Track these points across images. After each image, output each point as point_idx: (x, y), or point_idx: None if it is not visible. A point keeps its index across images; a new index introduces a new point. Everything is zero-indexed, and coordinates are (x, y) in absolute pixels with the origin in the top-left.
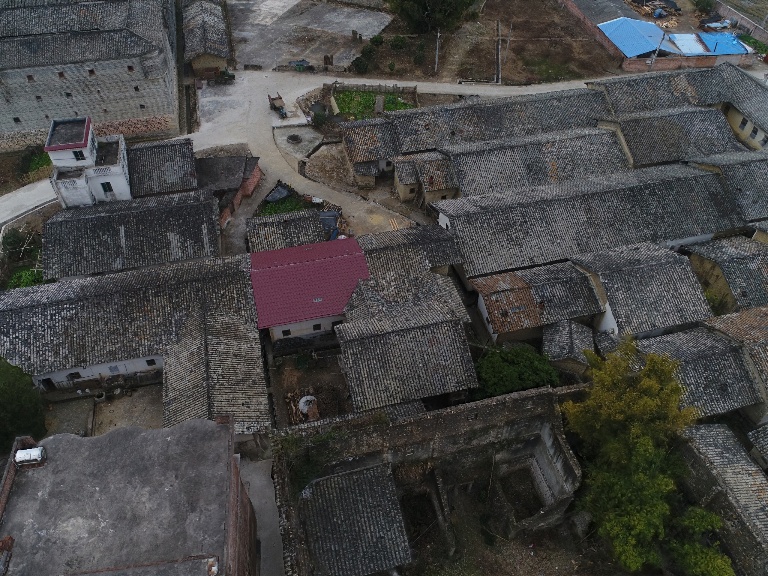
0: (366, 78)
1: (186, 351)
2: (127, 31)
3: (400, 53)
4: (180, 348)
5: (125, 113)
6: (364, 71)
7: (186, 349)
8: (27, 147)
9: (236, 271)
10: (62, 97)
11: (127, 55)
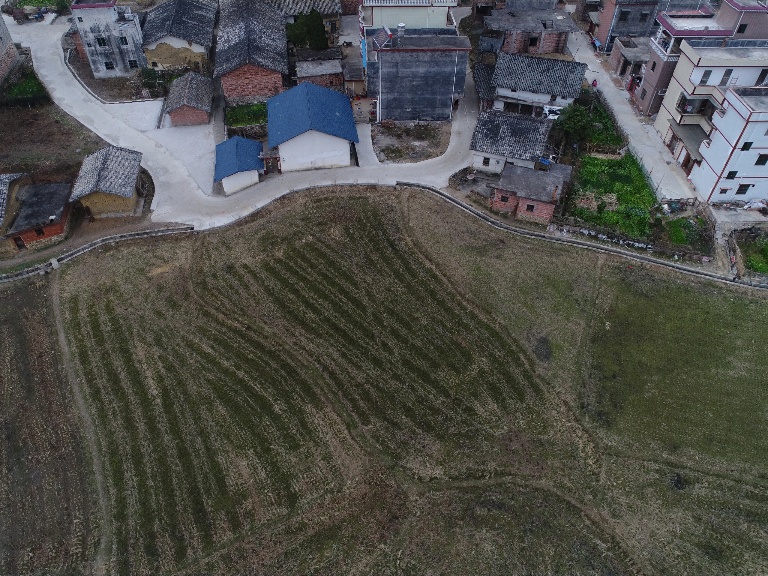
0: None
1: (290, 5)
2: None
3: None
4: (287, 8)
5: None
6: None
7: (289, 5)
8: None
9: None
10: None
11: None
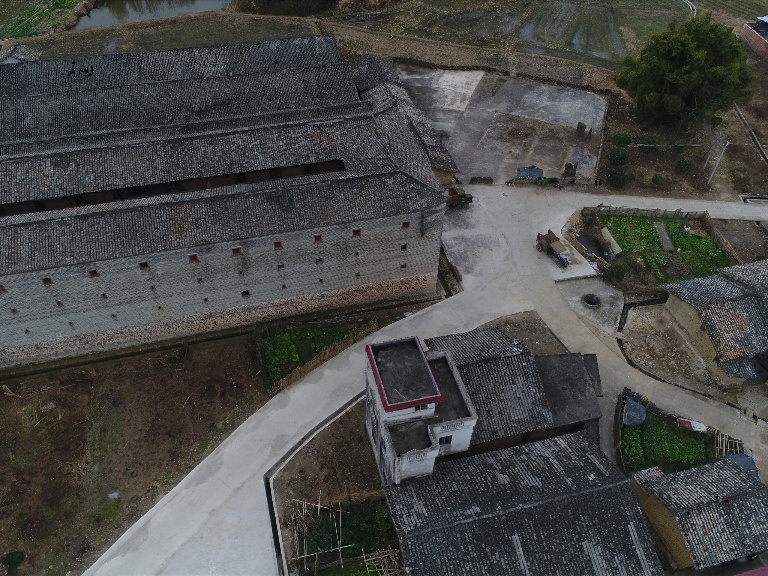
0: (627, 195)
1: None
2: (402, 174)
3: (647, 154)
4: None
5: (380, 275)
6: (623, 185)
7: None
8: (257, 328)
9: None
10: (310, 263)
11: (409, 211)
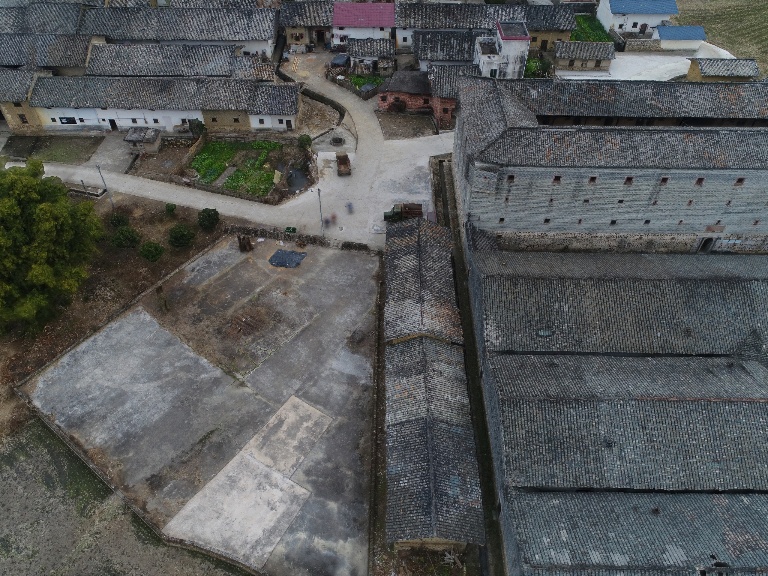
0: None
1: None
2: None
3: (125, 256)
4: None
5: None
6: None
7: None
8: None
9: (403, 4)
10: None
11: None
